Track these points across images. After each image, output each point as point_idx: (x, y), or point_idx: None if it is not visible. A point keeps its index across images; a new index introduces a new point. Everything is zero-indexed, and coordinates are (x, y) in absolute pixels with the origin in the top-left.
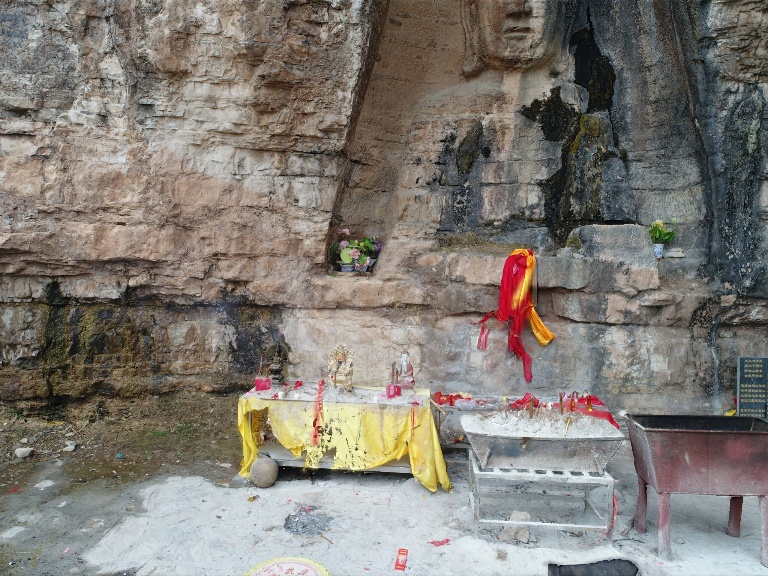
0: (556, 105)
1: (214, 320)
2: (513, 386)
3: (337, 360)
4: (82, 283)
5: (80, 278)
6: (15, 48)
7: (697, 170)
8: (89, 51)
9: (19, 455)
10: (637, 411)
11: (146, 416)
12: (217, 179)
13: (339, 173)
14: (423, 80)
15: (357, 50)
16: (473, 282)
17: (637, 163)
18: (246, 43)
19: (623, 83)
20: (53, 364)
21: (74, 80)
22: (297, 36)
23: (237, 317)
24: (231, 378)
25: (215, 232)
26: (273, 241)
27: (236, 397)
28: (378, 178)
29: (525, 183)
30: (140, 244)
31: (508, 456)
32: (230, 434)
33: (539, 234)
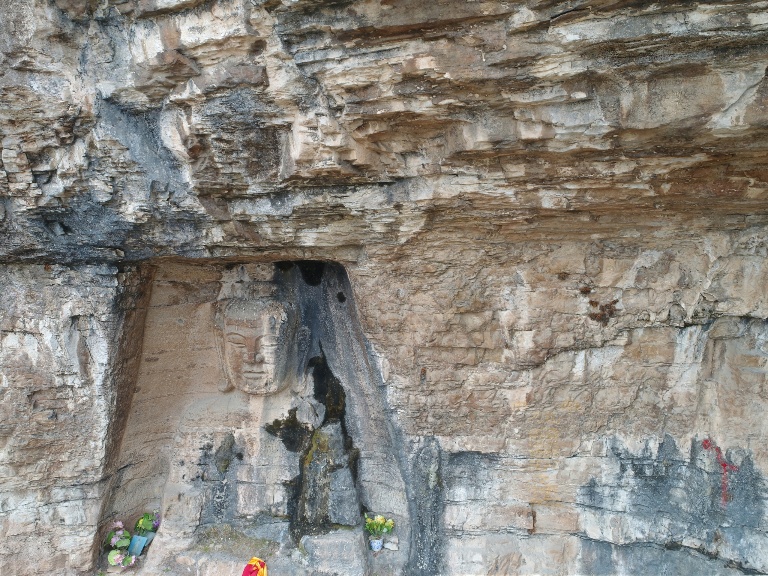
0: (293, 424)
1: None
2: None
3: None
4: None
5: None
6: None
7: (404, 483)
8: None
9: None
10: None
11: None
12: None
13: (102, 494)
14: (186, 392)
15: (103, 413)
16: None
17: (368, 460)
18: None
19: (351, 400)
20: None
21: None
22: (43, 414)
23: None
24: None
25: None
26: (39, 562)
27: None
28: (154, 466)
29: (272, 483)
30: None
31: None
32: None
33: (282, 531)
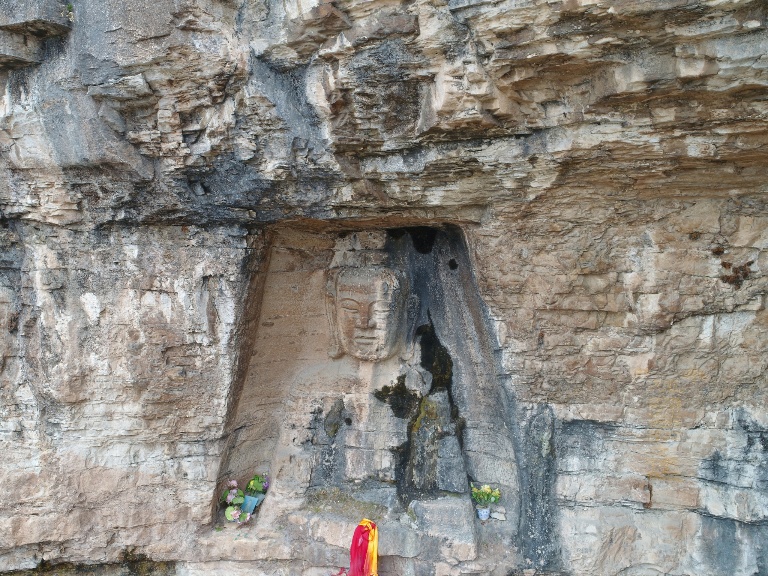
0: (402, 390)
1: (118, 575)
2: None
3: None
4: (4, 560)
5: (3, 556)
6: None
7: (513, 452)
8: (6, 383)
9: None
10: None
11: None
12: (116, 469)
13: (221, 451)
14: (297, 358)
15: (227, 371)
16: (331, 543)
17: (474, 430)
18: (131, 381)
19: (459, 369)
20: None
21: None
22: (175, 370)
23: (137, 571)
24: None
25: (115, 510)
26: (165, 513)
27: None
28: (264, 430)
29: (380, 449)
30: (51, 530)
31: None
32: None
33: (389, 495)
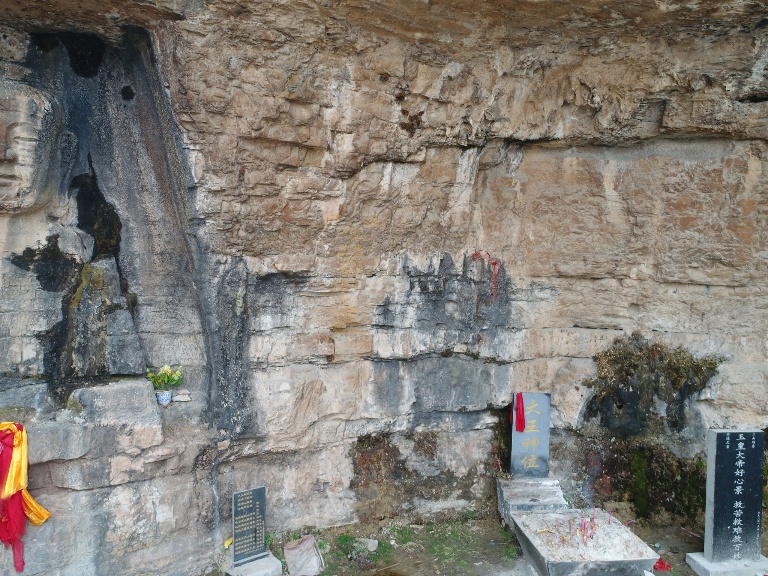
0: (54, 254)
1: None
2: None
3: None
4: None
5: None
6: None
7: (199, 321)
8: None
9: None
10: (143, 567)
11: None
12: None
13: None
14: None
15: None
16: None
17: (147, 307)
18: None
19: (129, 232)
20: None
21: None
22: None
23: None
24: None
25: None
26: None
27: None
28: None
29: (19, 336)
30: None
31: None
32: None
33: (37, 393)
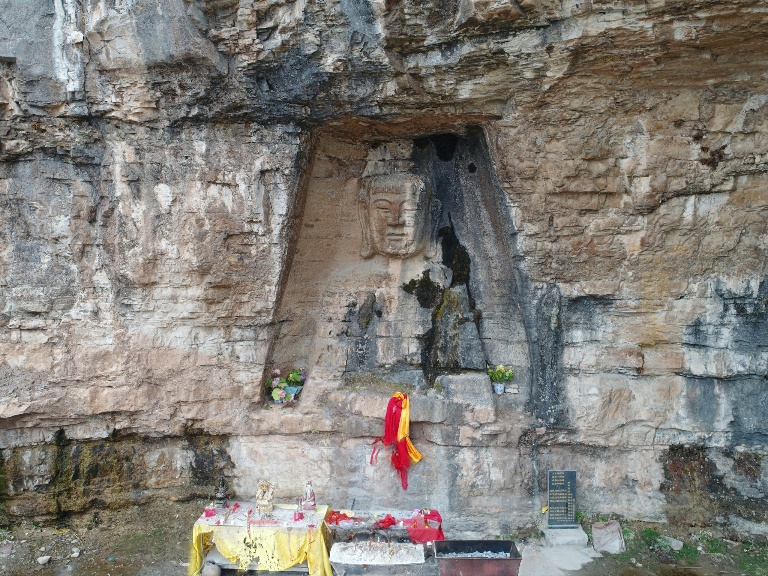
0: (427, 283)
1: (178, 447)
2: (394, 492)
3: (262, 490)
4: (81, 429)
5: (80, 425)
6: (32, 270)
7: (525, 333)
8: (85, 268)
9: (41, 562)
10: (480, 509)
11: (129, 522)
12: (179, 349)
13: (269, 337)
14: (333, 259)
15: (278, 260)
16: (367, 415)
17: (489, 320)
18: (197, 264)
19: (476, 265)
20: (61, 488)
21: (74, 289)
22: (234, 256)
23: (195, 444)
24: (191, 490)
25: (178, 386)
26: (221, 390)
27: (195, 504)
28: (302, 327)
29: (407, 337)
30: (123, 401)
31: (356, 574)
32: (190, 535)
33: (417, 376)
